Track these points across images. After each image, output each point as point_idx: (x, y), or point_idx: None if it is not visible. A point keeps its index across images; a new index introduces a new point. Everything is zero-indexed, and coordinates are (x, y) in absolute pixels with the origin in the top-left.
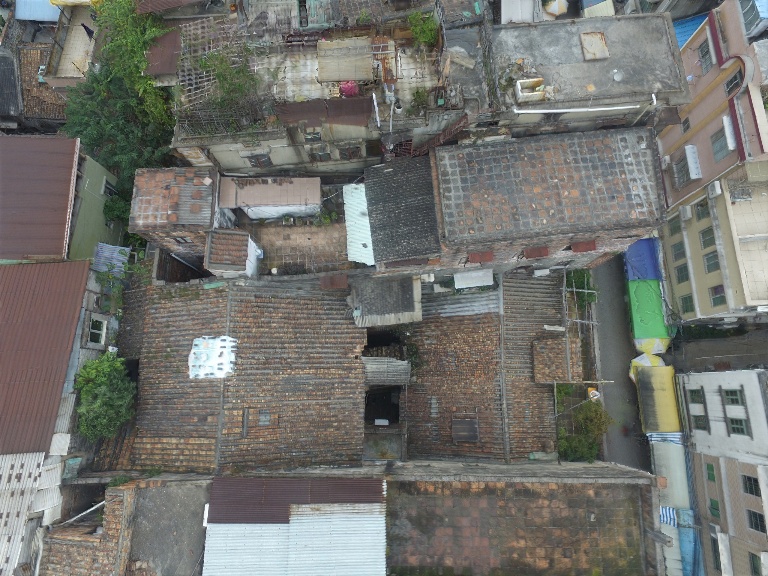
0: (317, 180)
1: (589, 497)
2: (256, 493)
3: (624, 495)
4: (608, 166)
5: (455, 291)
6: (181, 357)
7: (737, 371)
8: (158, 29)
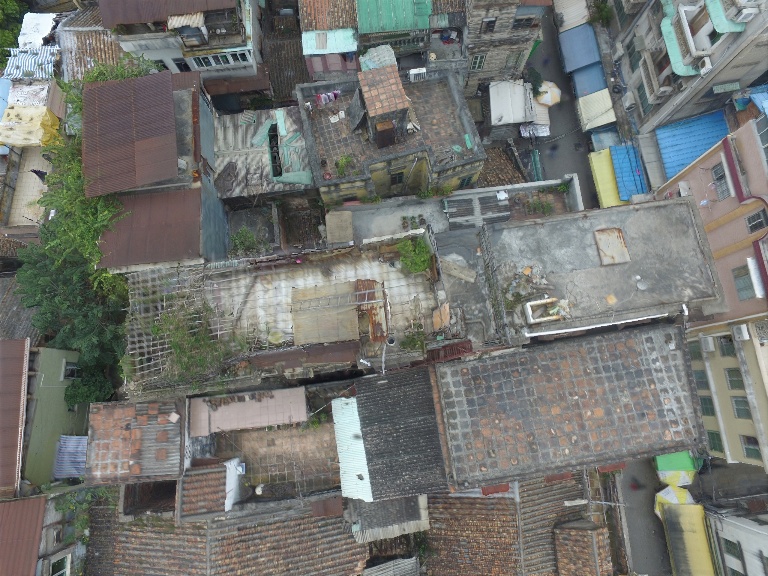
0: (301, 390)
1: None
2: None
3: None
4: (634, 374)
5: None
6: None
7: None
8: (111, 209)
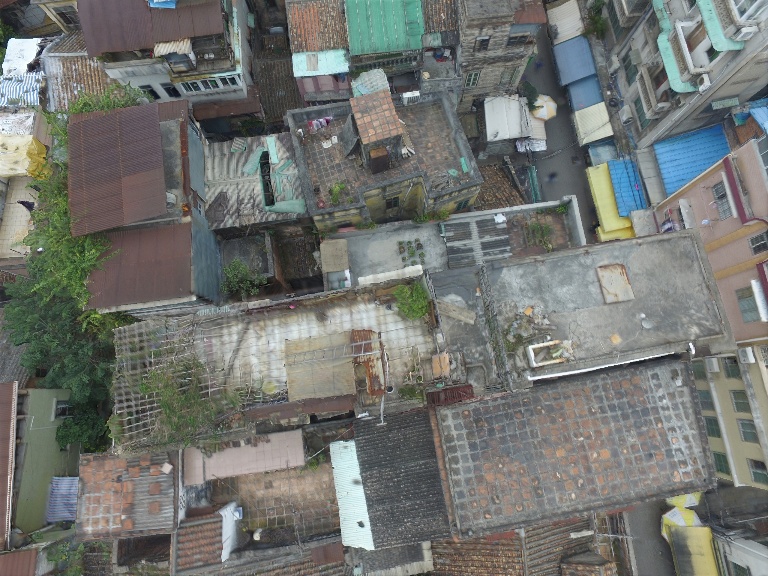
0: (298, 433)
1: None
2: None
3: None
4: (640, 413)
5: None
6: None
7: None
8: (99, 246)
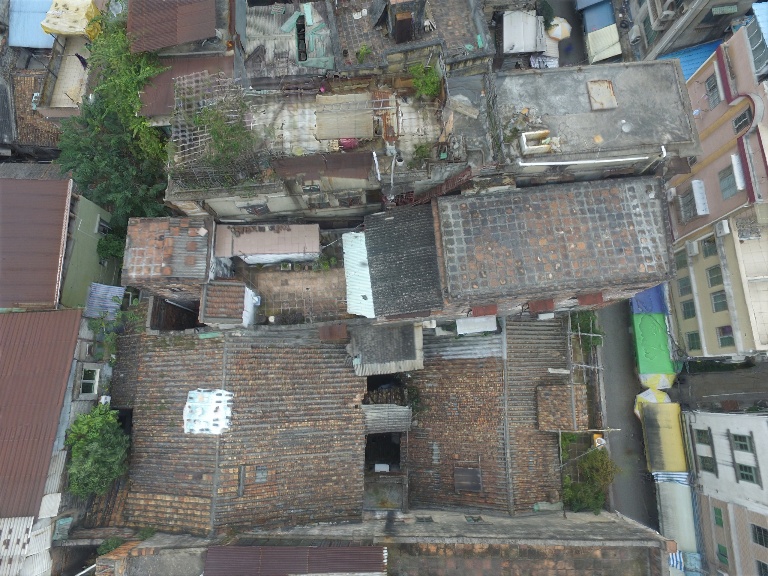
0: (316, 227)
1: (596, 558)
2: (252, 563)
3: (632, 556)
4: (616, 217)
5: (457, 335)
6: (176, 409)
7: (746, 416)
8: (153, 67)
